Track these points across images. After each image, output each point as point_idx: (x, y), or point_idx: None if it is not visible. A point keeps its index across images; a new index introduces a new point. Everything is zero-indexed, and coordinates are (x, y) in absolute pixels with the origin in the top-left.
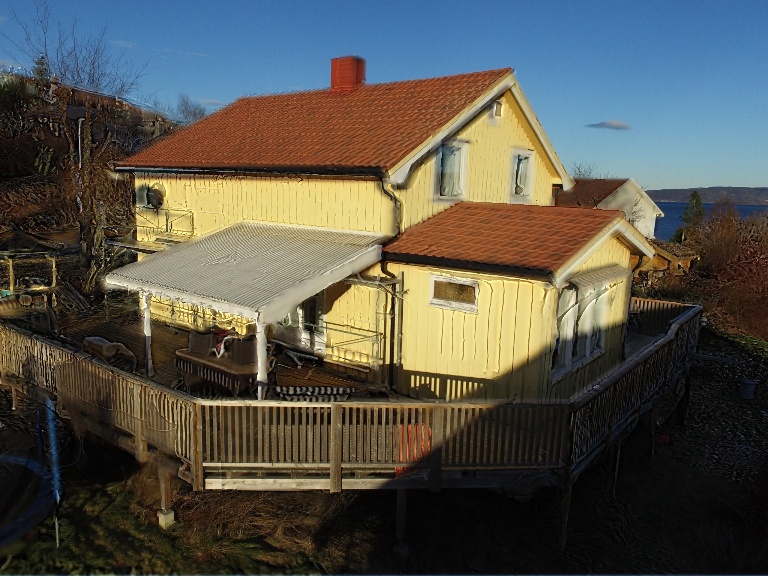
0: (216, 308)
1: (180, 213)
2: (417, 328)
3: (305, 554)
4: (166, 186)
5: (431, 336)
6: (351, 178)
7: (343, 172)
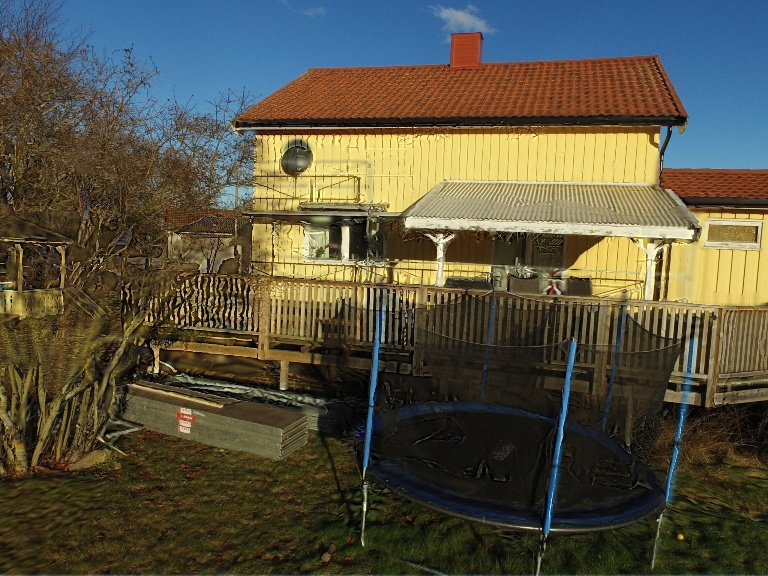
0: (619, 233)
1: (336, 179)
2: (686, 271)
3: (762, 469)
4: (314, 149)
5: (704, 277)
6: (606, 131)
7: (619, 121)
